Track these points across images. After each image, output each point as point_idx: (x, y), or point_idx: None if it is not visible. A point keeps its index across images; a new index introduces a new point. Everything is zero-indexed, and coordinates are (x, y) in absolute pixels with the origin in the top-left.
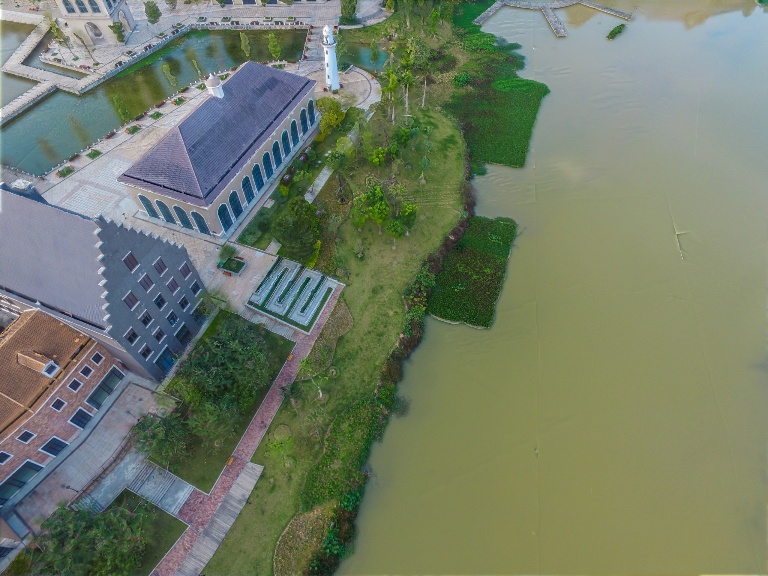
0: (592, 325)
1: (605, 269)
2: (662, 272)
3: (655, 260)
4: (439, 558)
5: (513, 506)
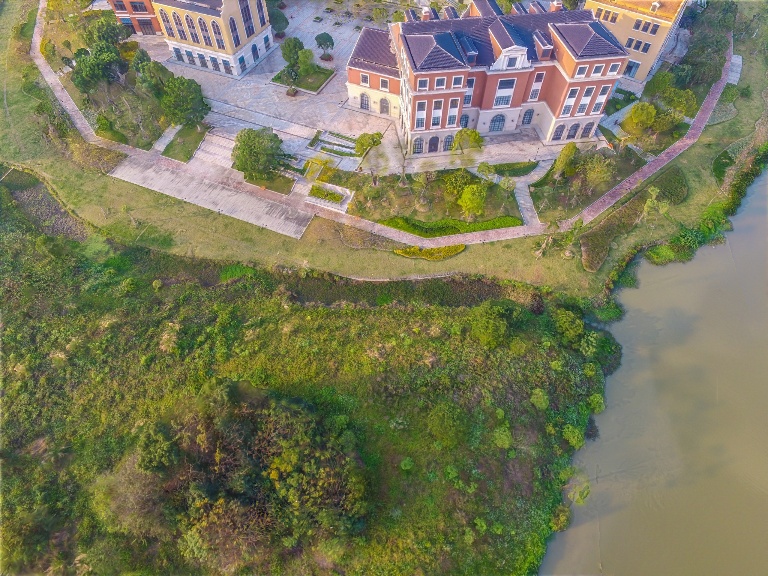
0: None
1: None
2: None
3: None
4: None
5: None
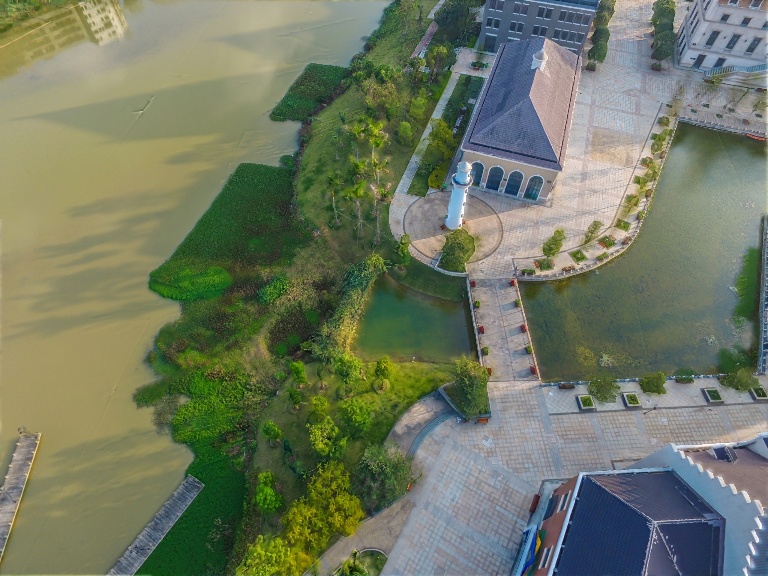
0: (246, 65)
1: (217, 90)
2: (177, 90)
3: (176, 96)
4: (350, 7)
5: (317, 16)
